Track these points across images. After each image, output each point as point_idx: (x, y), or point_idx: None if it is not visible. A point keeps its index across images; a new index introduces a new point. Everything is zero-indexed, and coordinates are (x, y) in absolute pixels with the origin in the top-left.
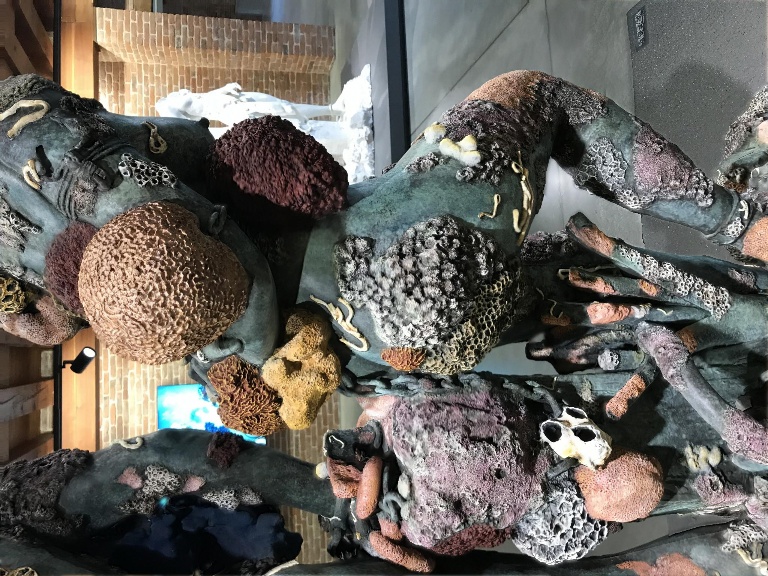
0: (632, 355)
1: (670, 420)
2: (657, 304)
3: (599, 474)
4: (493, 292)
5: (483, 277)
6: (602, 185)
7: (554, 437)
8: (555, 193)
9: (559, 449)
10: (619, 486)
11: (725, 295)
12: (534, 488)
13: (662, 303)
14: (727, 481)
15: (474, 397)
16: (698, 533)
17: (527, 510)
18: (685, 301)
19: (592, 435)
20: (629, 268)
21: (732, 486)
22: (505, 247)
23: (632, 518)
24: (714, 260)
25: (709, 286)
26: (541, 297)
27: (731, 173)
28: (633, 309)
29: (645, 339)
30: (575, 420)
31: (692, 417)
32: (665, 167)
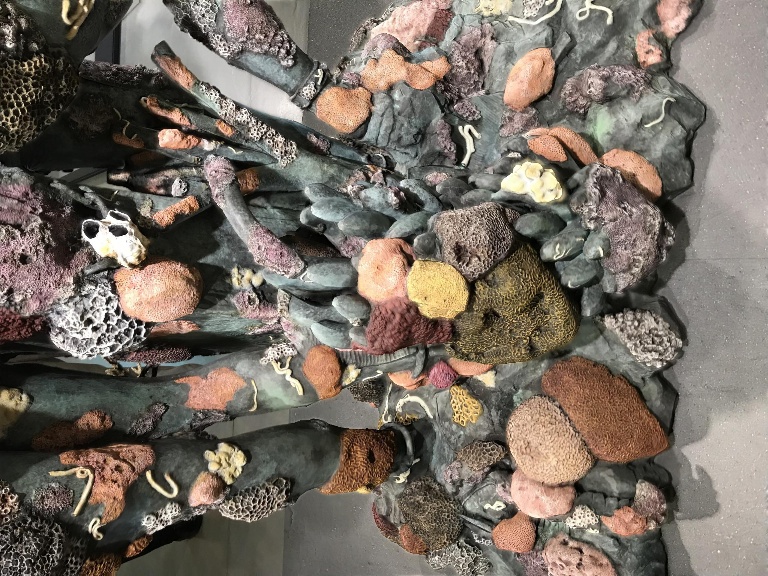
0: (201, 186)
1: (224, 245)
2: (231, 144)
3: (135, 274)
4: (23, 70)
5: (10, 50)
6: (196, 25)
7: (92, 234)
8: (246, 97)
9: (97, 247)
10: (151, 284)
11: (293, 148)
12: (65, 280)
13: (236, 144)
14: (265, 300)
15: (12, 188)
16: (247, 351)
17: (55, 300)
18: (258, 147)
19: (124, 231)
20: (211, 108)
21: (268, 304)
22: (48, 33)
23: (165, 318)
24: (299, 124)
25: (279, 137)
26: (118, 118)
27: (342, 65)
28: (203, 141)
29: (206, 166)
30: (116, 221)
31: (245, 245)
32: (252, 19)
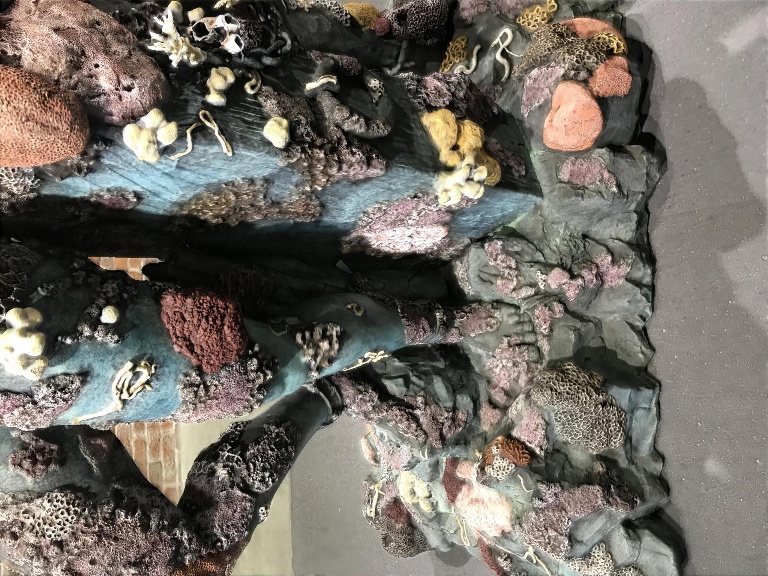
0: None
1: None
2: None
3: None
4: None
5: None
6: None
7: None
8: None
9: None
10: None
11: None
12: None
13: None
14: None
15: None
16: None
17: None
18: None
19: None
20: None
21: None
22: None
23: None
24: None
25: None
26: None
27: (478, 473)
28: None
29: None
30: None
31: None
32: None
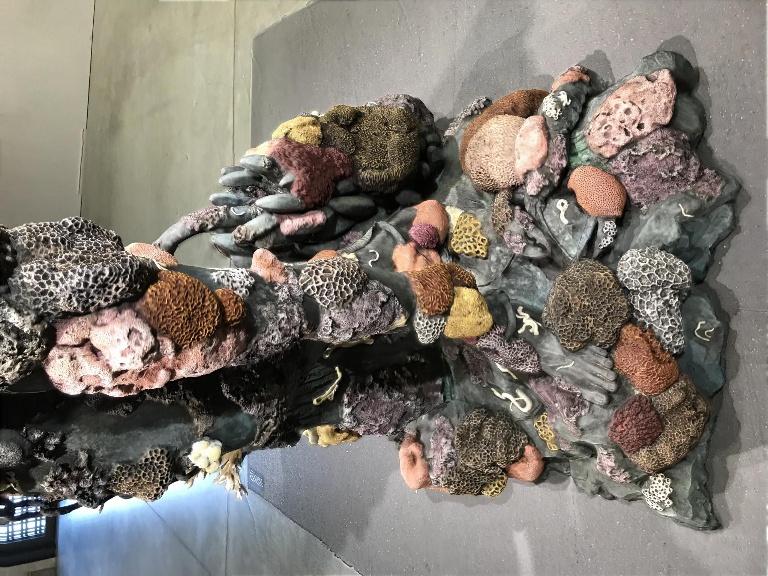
0: None
1: None
2: None
3: None
4: None
5: None
6: None
7: None
8: None
9: None
10: None
11: None
12: None
13: None
14: None
15: None
16: None
17: None
18: None
19: None
20: None
21: None
22: None
23: None
24: None
25: None
26: None
27: None
28: None
29: None
30: None
31: None
32: None
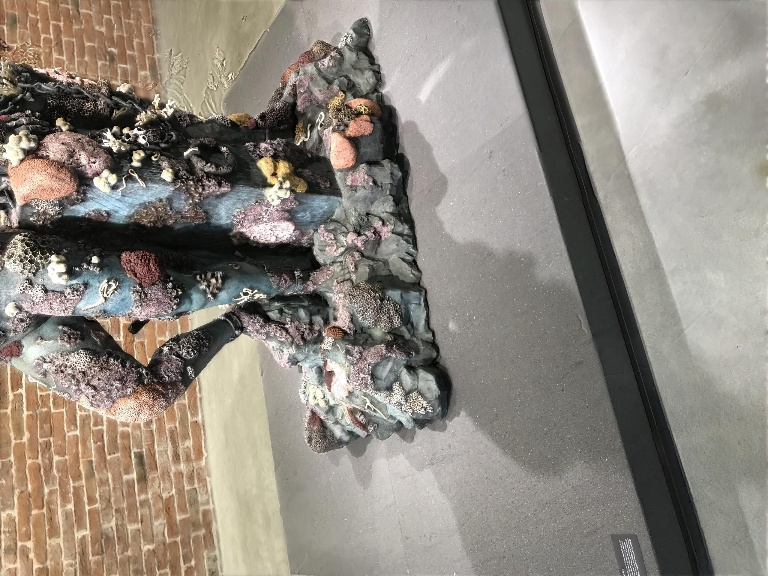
0: None
1: None
2: None
3: None
4: None
5: None
6: None
7: None
8: None
9: None
10: None
11: None
12: None
13: None
14: None
15: None
16: None
17: None
18: None
19: None
20: None
21: None
22: None
23: None
24: None
25: None
26: None
27: None
28: None
29: None
30: None
31: None
32: None
